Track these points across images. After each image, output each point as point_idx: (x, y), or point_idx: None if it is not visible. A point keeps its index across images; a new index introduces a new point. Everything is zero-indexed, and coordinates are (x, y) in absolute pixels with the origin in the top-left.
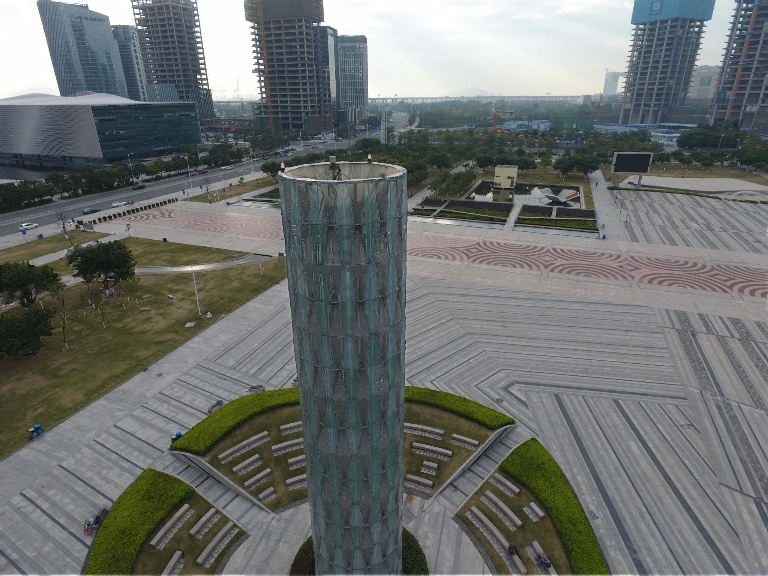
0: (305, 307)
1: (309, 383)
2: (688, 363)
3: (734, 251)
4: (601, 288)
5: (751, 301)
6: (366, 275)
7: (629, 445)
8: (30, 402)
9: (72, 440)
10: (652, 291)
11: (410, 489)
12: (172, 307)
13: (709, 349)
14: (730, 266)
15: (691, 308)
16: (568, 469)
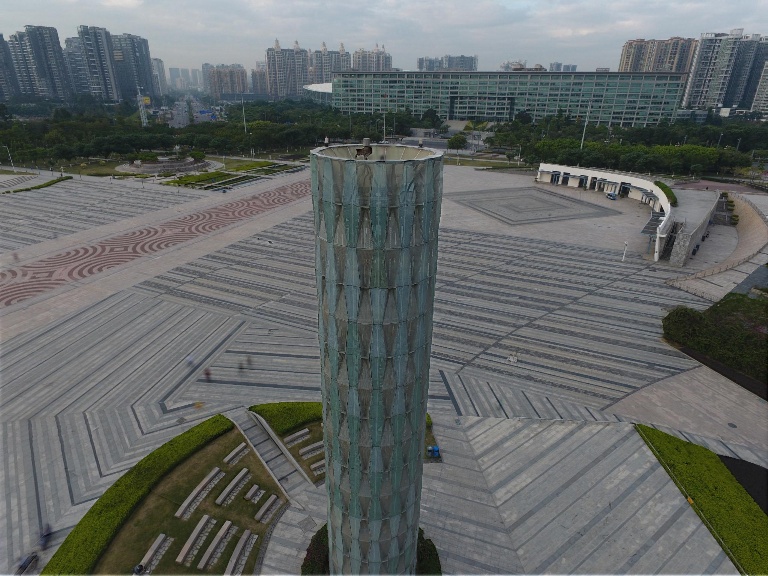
0: (423, 291)
1: (416, 372)
2: (209, 305)
3: (89, 229)
4: (57, 301)
5: (162, 254)
6: None
7: (276, 362)
8: None
9: None
10: (99, 281)
11: (273, 519)
12: None
13: (200, 291)
14: (108, 240)
15: (144, 277)
16: (287, 399)
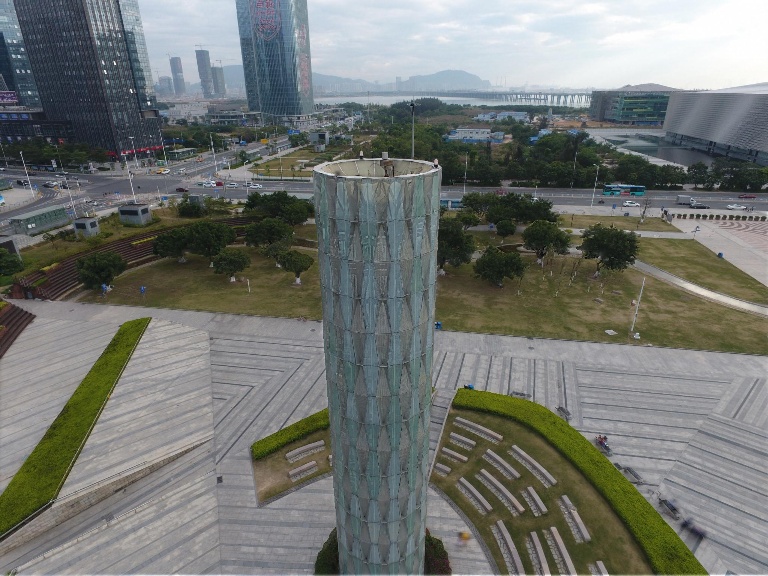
0: None
1: None
2: None
3: None
4: None
5: None
6: (324, 263)
7: None
8: (460, 311)
9: (441, 343)
10: None
11: None
12: (621, 311)
13: None
14: None
15: None
16: None
